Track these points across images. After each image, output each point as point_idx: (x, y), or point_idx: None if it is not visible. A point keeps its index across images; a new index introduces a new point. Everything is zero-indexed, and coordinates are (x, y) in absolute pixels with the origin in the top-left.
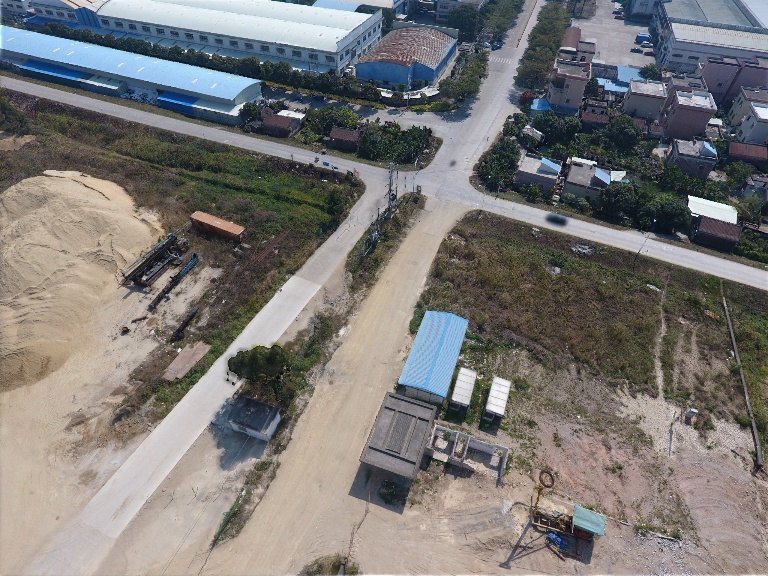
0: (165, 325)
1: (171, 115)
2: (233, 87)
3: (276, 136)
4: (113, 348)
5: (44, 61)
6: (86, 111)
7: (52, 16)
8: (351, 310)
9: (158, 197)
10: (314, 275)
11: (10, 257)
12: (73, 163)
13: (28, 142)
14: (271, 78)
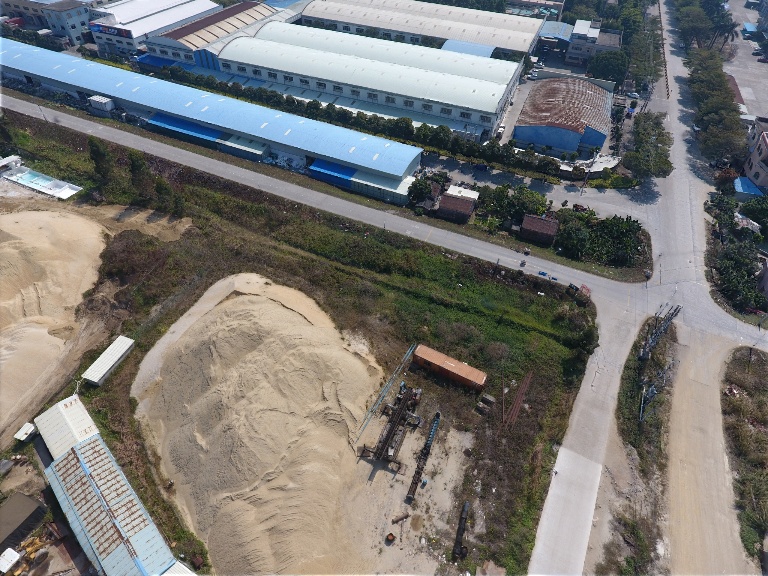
0: (435, 529)
1: (334, 193)
2: (398, 159)
3: (451, 220)
4: (383, 568)
5: (175, 116)
6: (239, 185)
7: (166, 56)
8: (656, 510)
9: (357, 314)
10: (586, 447)
11: (244, 433)
12: (247, 261)
13: (188, 229)
14: (429, 144)
